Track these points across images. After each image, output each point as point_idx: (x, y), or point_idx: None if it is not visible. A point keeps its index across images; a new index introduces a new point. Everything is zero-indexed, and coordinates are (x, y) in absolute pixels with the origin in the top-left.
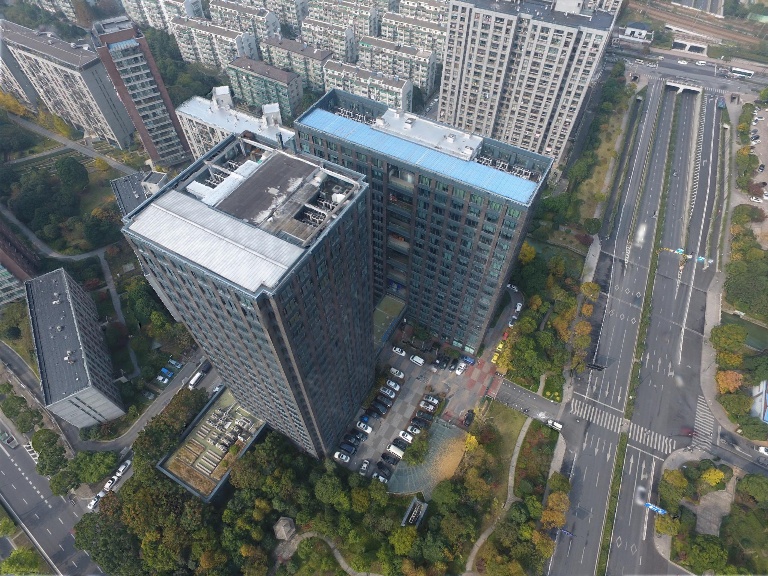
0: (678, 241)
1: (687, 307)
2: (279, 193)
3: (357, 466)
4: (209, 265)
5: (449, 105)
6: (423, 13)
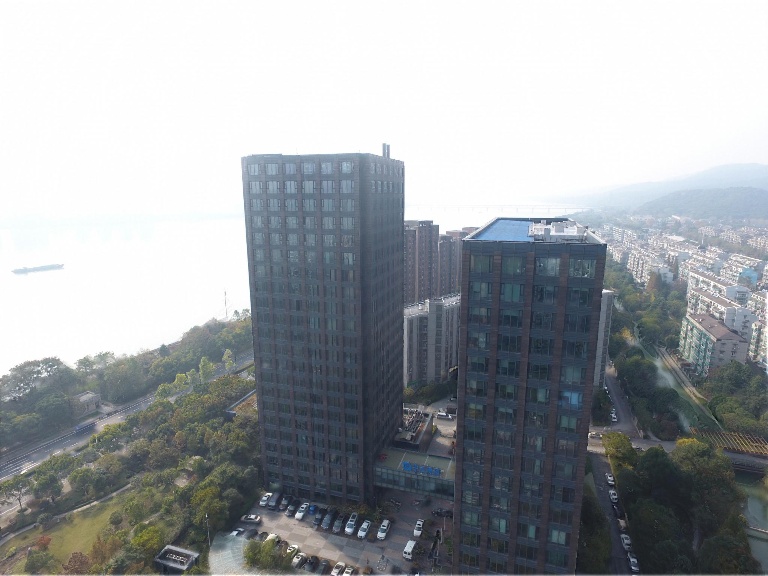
0: None
1: None
2: None
3: None
4: None
5: None
6: None
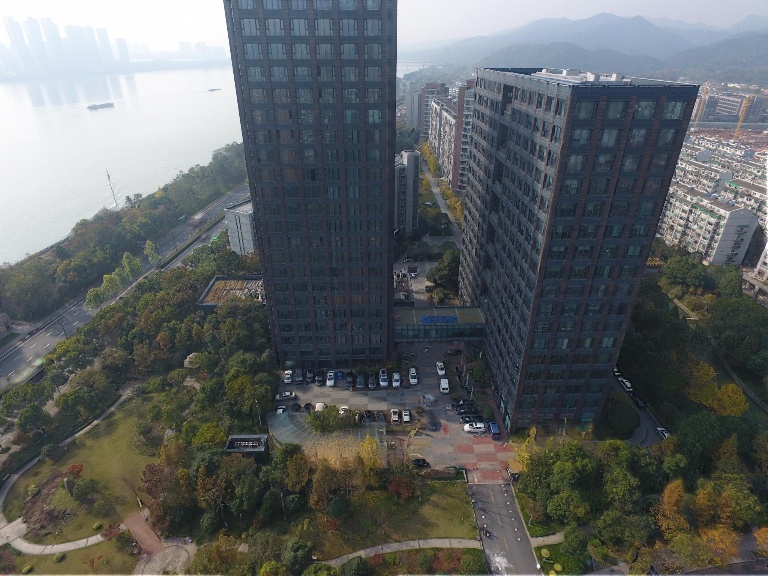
0: None
1: None
2: None
3: None
4: None
5: None
6: None
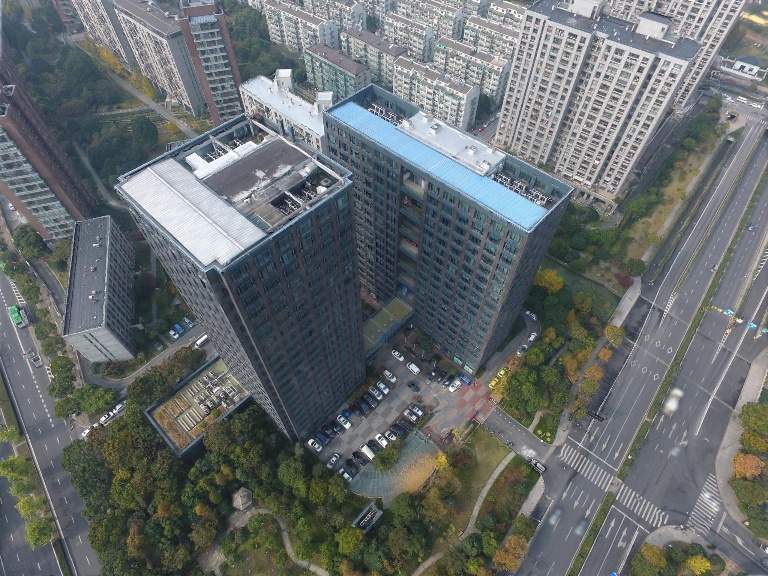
0: (733, 301)
1: (723, 375)
2: (265, 177)
3: (327, 457)
4: (176, 233)
5: (510, 118)
6: (511, 21)
